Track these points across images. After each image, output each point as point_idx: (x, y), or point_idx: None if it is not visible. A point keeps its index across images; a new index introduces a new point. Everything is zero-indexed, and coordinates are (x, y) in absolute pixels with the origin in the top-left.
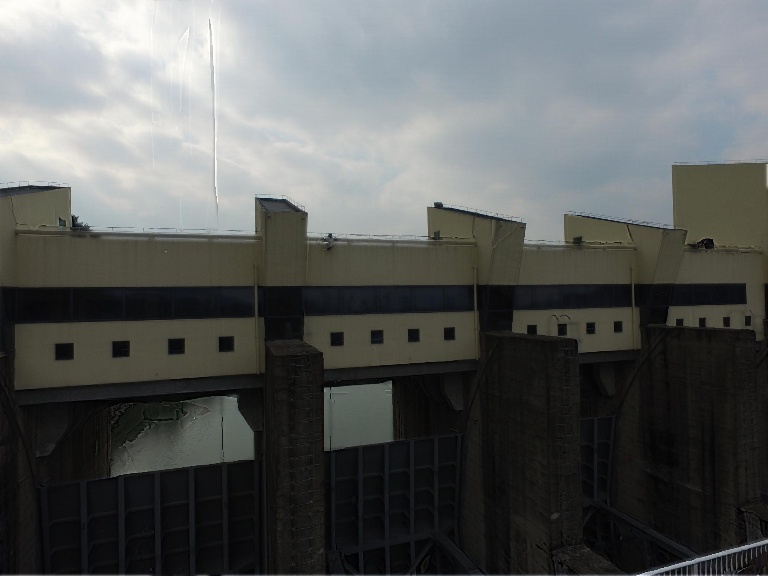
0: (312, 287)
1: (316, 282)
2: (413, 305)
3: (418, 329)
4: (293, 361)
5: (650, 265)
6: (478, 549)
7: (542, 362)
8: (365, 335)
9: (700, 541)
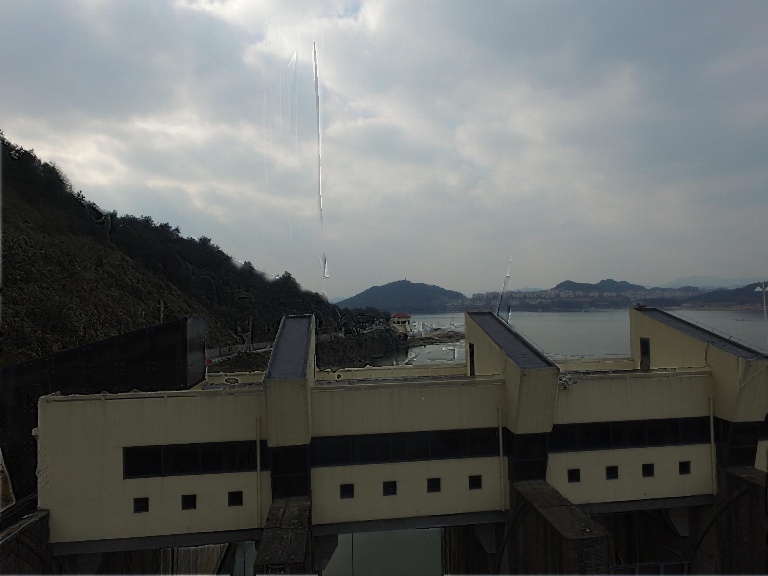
0: None
1: None
2: (646, 439)
3: (652, 464)
4: (585, 546)
5: None
6: None
7: None
8: (600, 471)
9: None
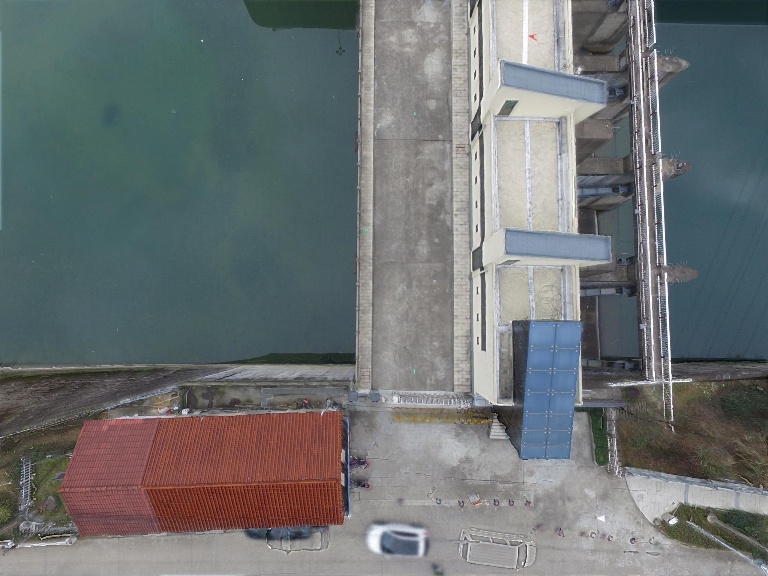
0: None
1: None
2: None
3: None
4: None
5: None
6: None
7: None
8: None
9: None
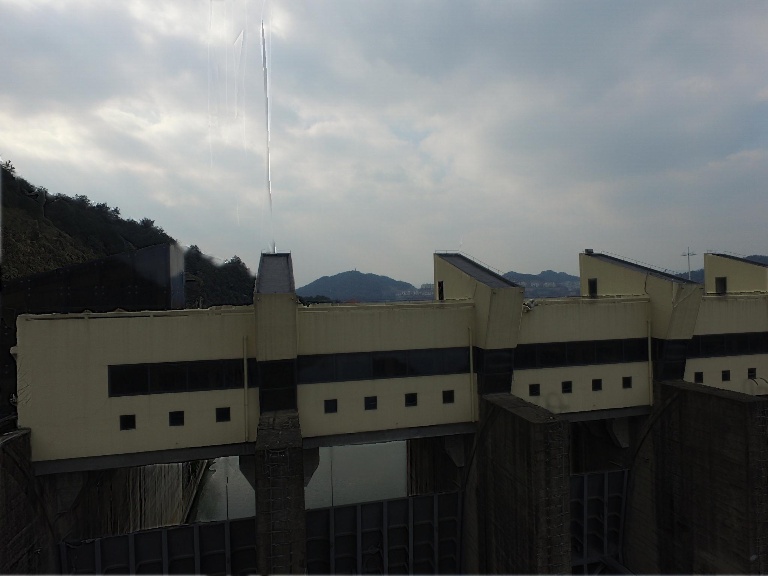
0: None
1: None
2: (596, 358)
3: (600, 379)
4: (549, 428)
5: None
6: (649, 575)
7: (740, 420)
8: (557, 386)
9: None
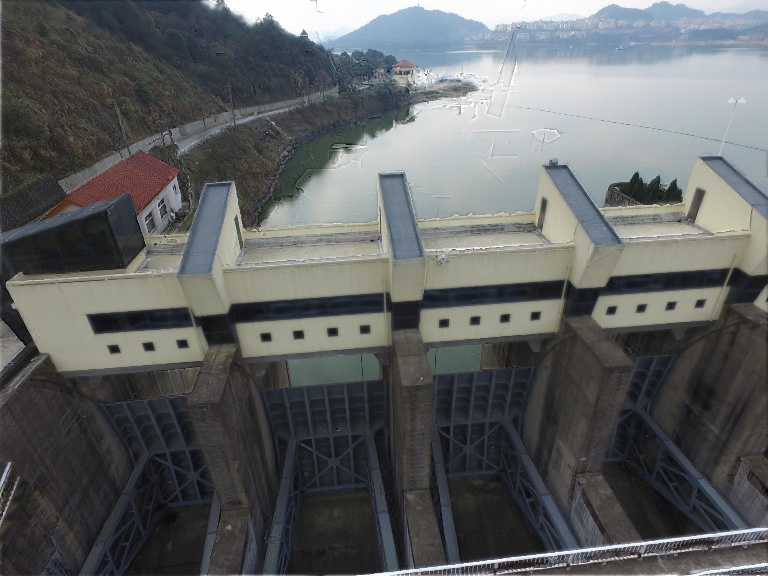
0: (427, 290)
1: (430, 287)
2: (508, 298)
3: (509, 314)
4: (414, 390)
5: (756, 259)
6: (533, 435)
7: (600, 377)
8: (466, 320)
9: (704, 459)
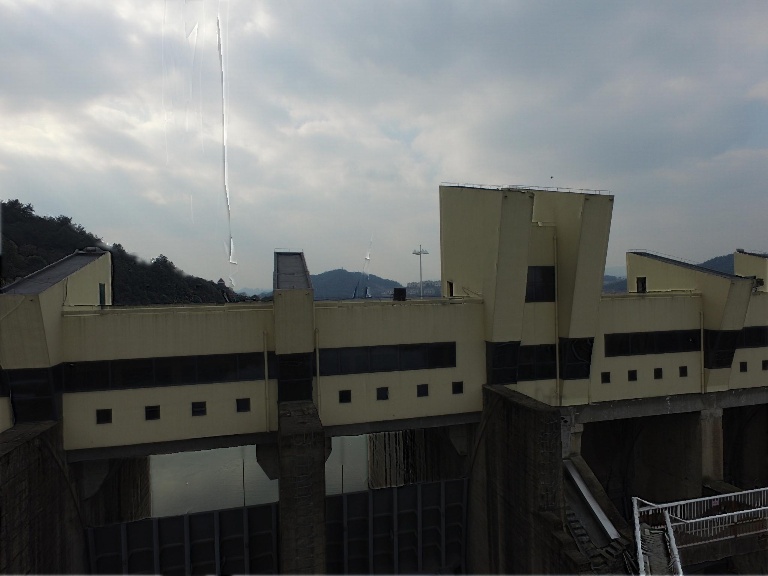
0: None
1: None
2: None
3: None
4: None
5: (274, 331)
6: None
7: None
8: None
9: None
